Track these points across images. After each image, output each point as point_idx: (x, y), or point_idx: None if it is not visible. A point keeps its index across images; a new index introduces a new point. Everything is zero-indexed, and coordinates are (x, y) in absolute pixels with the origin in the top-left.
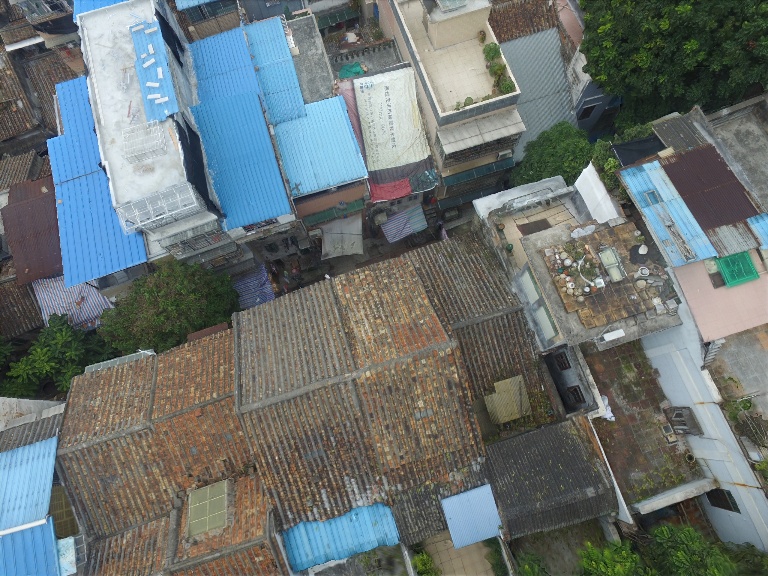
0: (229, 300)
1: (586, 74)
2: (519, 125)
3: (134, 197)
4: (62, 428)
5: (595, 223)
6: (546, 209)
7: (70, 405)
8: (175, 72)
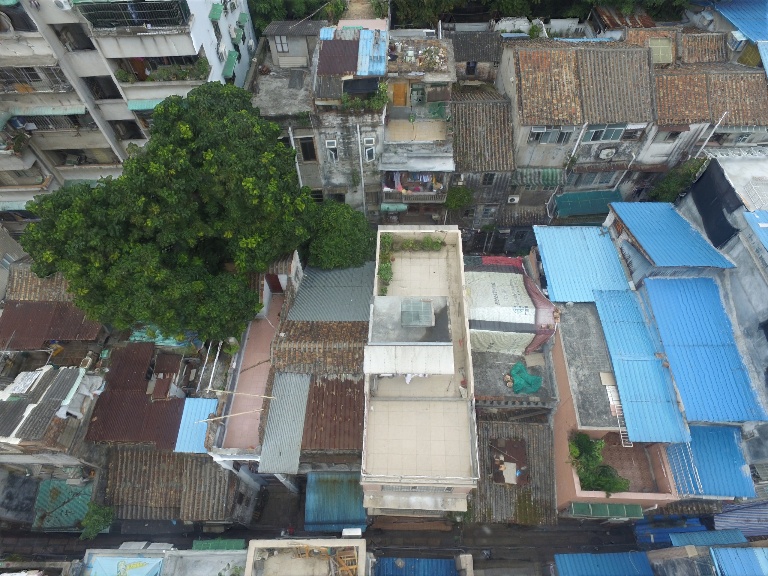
0: None
1: (295, 258)
2: None
3: (764, 163)
4: (767, 88)
5: (406, 76)
6: (424, 107)
7: (767, 103)
8: (763, 283)
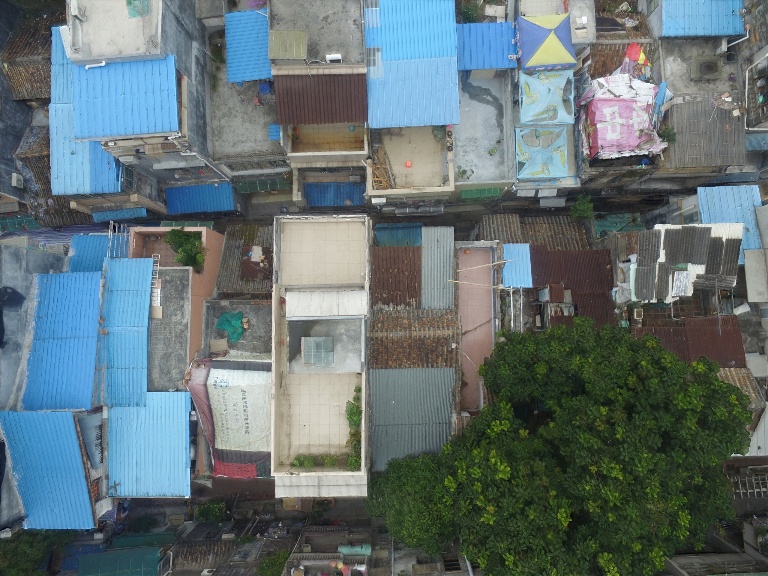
0: (41, 550)
1: None
2: (362, 488)
3: None
4: None
5: None
6: None
7: None
8: None
